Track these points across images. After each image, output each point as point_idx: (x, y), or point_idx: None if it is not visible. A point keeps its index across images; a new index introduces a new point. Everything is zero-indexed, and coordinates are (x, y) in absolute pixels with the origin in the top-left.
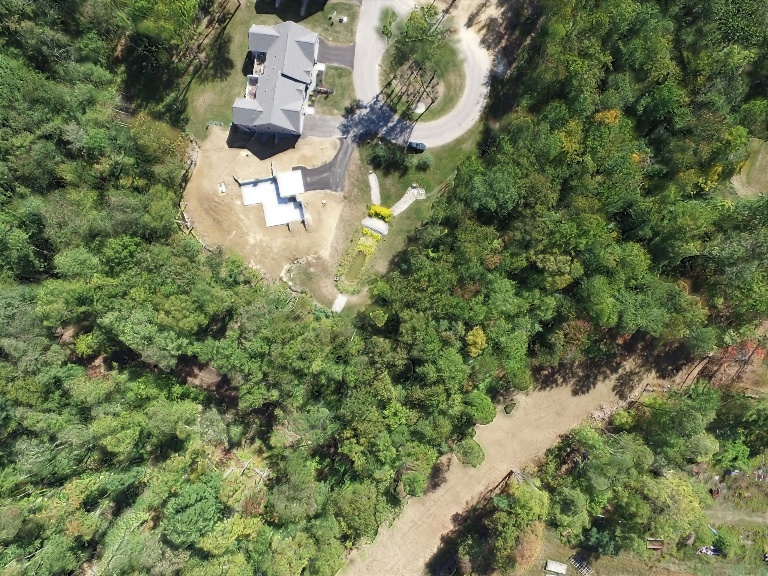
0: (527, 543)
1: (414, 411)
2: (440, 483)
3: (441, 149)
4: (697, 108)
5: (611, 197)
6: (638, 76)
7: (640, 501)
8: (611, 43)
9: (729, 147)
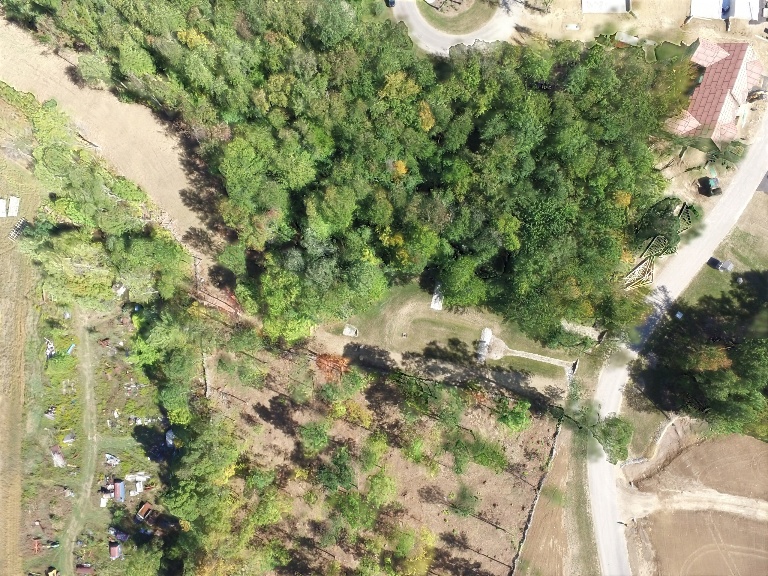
0: (2, 101)
1: (123, 3)
2: (78, 84)
3: (394, 23)
4: (457, 211)
5: (348, 129)
6: (475, 144)
7: (74, 241)
8: (501, 111)
9: (417, 233)
